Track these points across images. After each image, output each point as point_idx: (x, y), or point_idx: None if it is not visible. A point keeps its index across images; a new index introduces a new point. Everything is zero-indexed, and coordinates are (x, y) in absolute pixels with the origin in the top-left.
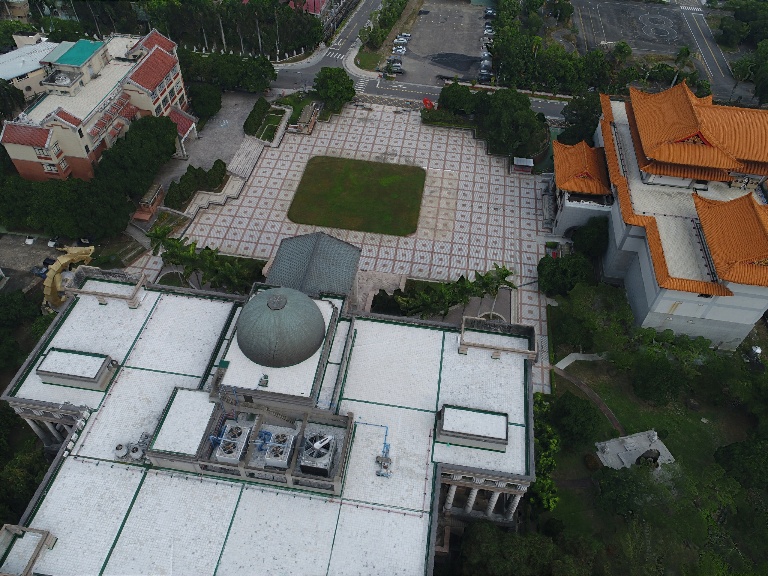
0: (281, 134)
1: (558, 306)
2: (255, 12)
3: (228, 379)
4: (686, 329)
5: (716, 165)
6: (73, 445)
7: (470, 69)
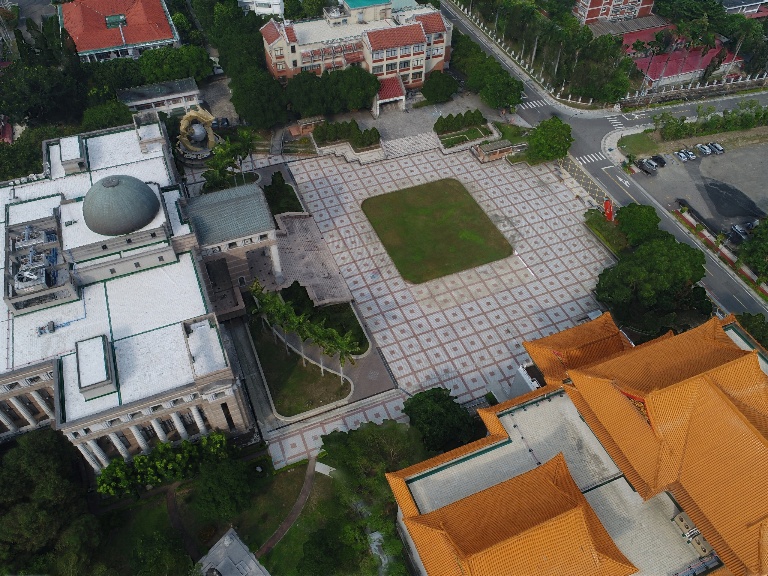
0: (462, 148)
1: (377, 425)
2: (561, 42)
3: (66, 207)
4: (421, 568)
5: (631, 457)
6: (20, 183)
7: (732, 218)
